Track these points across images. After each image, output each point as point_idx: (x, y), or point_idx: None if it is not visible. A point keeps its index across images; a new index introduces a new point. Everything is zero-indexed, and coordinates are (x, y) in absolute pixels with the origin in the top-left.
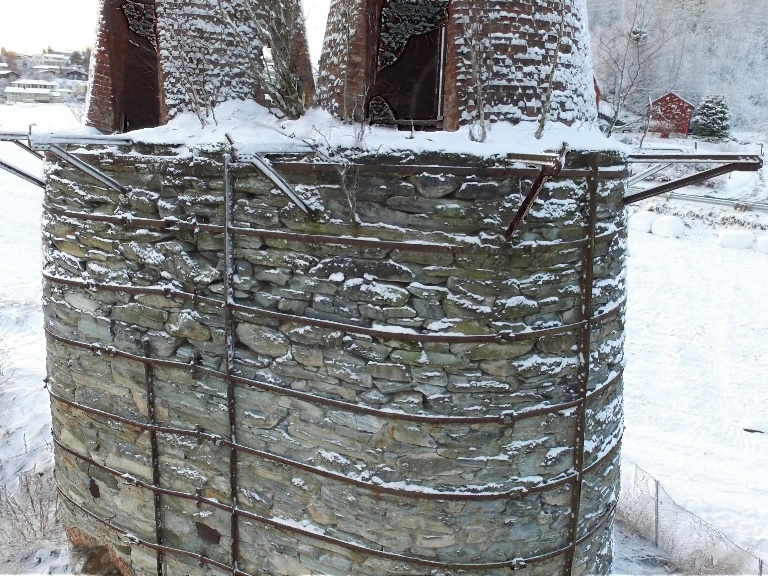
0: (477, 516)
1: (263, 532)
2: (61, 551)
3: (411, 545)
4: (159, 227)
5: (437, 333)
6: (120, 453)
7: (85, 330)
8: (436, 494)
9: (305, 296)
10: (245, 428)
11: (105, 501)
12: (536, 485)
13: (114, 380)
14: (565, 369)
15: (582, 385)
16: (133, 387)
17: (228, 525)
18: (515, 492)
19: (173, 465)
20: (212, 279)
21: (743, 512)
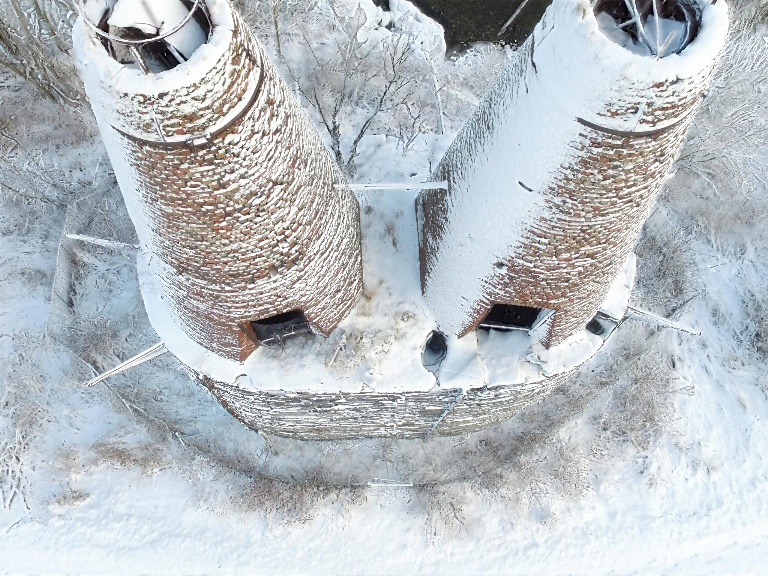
0: None
1: None
2: None
3: None
4: None
5: None
6: None
7: None
8: None
9: None
10: None
11: None
12: None
13: None
14: None
15: None
16: None
17: None
18: None
19: None
20: None
21: (128, 550)
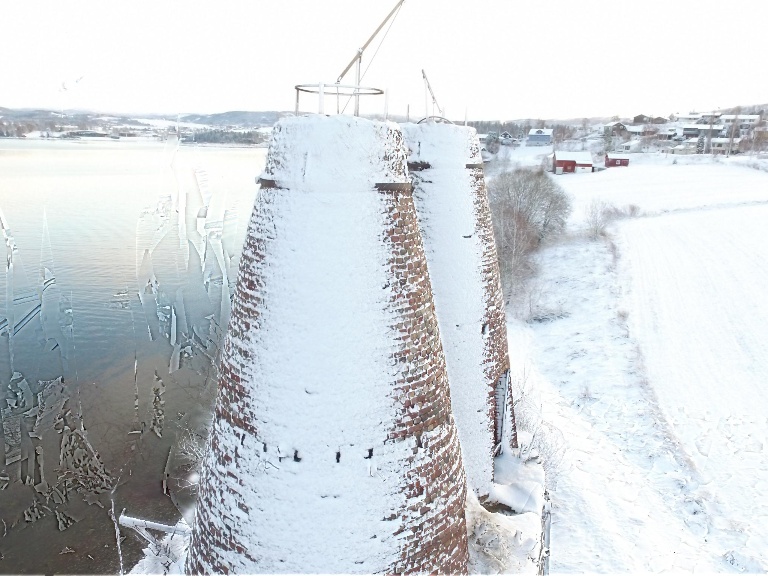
0: None
1: None
2: None
3: None
4: None
5: None
6: None
7: None
8: None
9: None
10: None
11: None
12: None
13: None
14: None
15: None
16: None
17: None
18: None
19: None
20: None
21: None
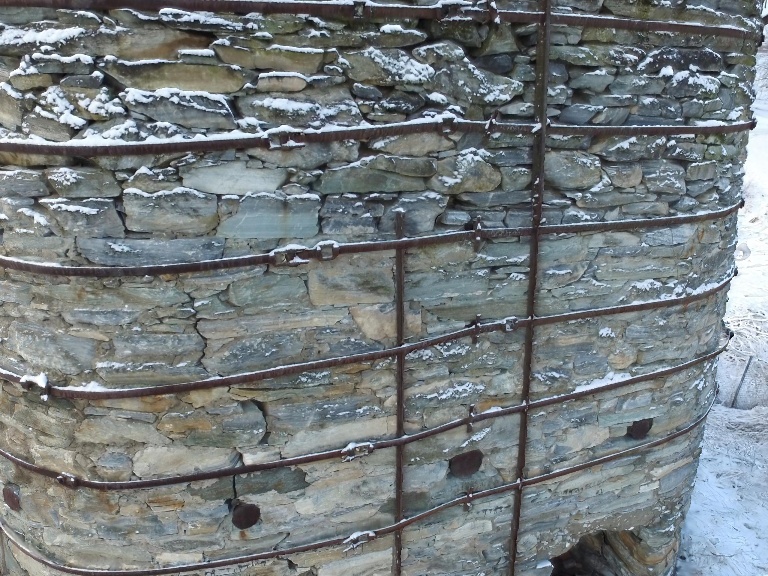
0: (724, 299)
1: (559, 415)
2: None
3: None
4: (419, 20)
5: None
6: (324, 421)
7: (247, 231)
8: (719, 286)
9: (633, 100)
10: (544, 294)
11: (273, 521)
12: None
13: (312, 304)
14: None
15: None
16: (362, 300)
17: (512, 432)
18: None
19: (430, 393)
20: (512, 95)
21: None
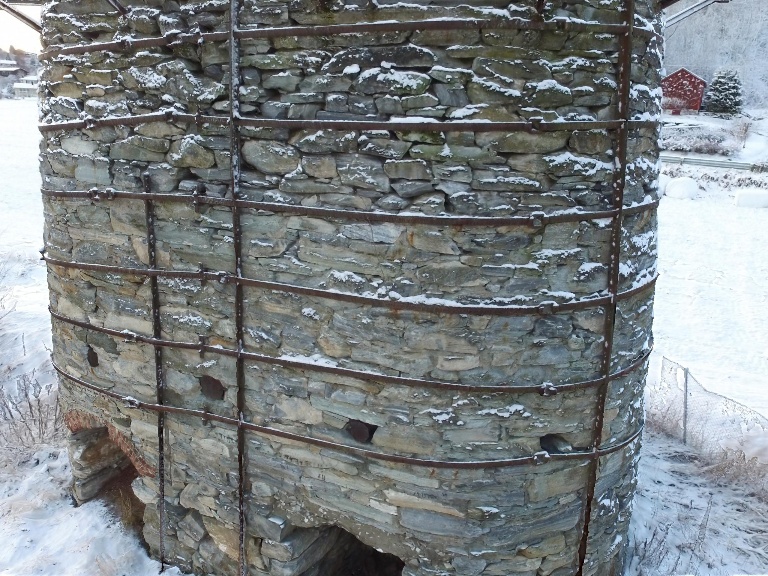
0: (503, 334)
1: (271, 375)
2: (60, 453)
3: (431, 369)
4: (160, 47)
5: (461, 120)
6: (119, 310)
7: (82, 177)
8: (459, 307)
9: (317, 97)
10: (252, 260)
11: (104, 369)
12: (568, 301)
13: (113, 229)
14: (600, 174)
15: (618, 193)
16: (133, 232)
17: (233, 373)
18: (545, 308)
19: (175, 314)
20: (217, 95)
21: None
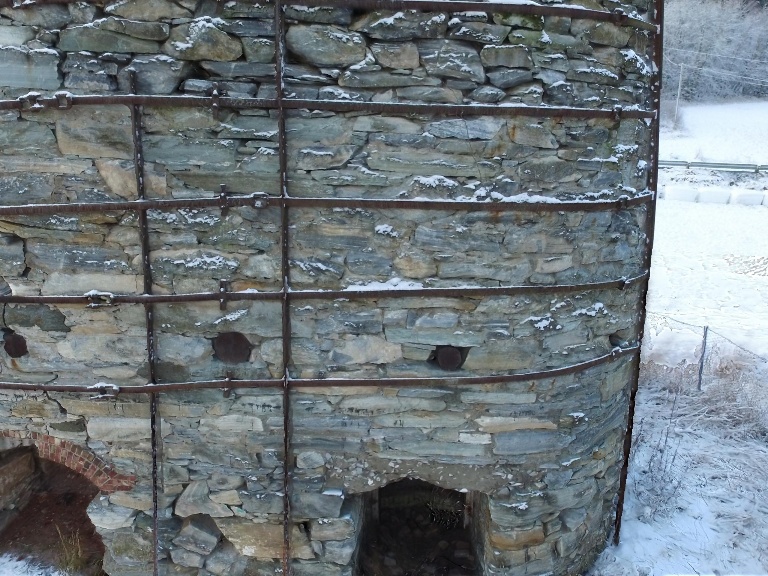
0: (592, 230)
1: (330, 314)
2: None
3: (531, 273)
4: None
5: (562, 4)
6: (74, 266)
7: (1, 80)
8: (559, 203)
9: None
10: (301, 174)
11: (38, 356)
12: (634, 196)
13: (61, 153)
14: None
15: (656, 95)
16: (102, 153)
17: (273, 321)
18: None
19: (177, 258)
20: None
21: None
